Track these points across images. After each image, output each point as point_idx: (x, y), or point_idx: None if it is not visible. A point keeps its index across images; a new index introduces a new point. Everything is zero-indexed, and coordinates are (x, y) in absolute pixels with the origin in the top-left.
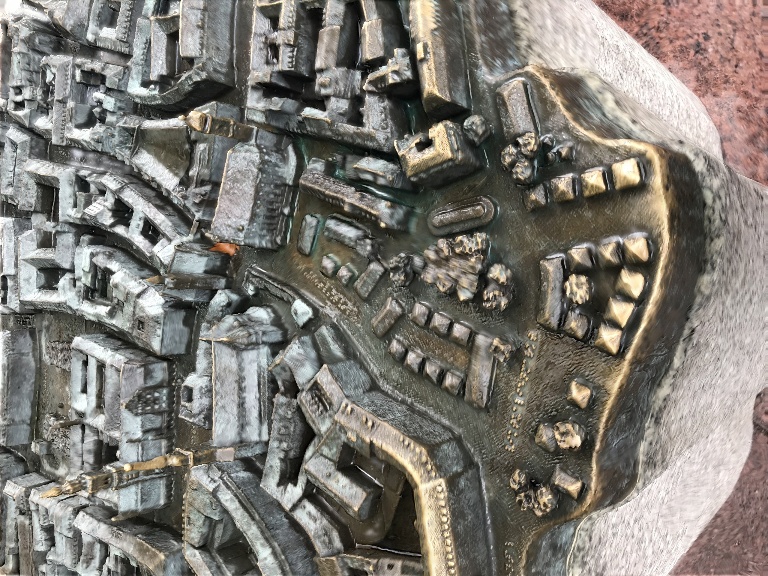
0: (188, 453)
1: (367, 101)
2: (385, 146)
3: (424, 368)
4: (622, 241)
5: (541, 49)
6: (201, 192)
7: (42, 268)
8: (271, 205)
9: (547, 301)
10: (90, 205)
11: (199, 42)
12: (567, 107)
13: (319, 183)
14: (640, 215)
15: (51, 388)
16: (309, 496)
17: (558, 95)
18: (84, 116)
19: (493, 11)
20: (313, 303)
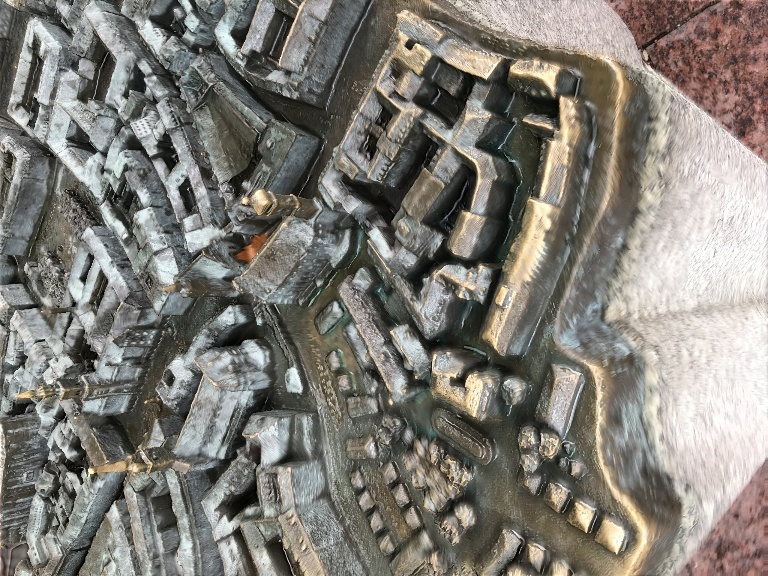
0: (149, 462)
1: (432, 285)
2: (428, 335)
3: (370, 515)
4: (574, 575)
5: (632, 287)
6: (247, 212)
7: None
8: (306, 274)
9: (489, 566)
10: (139, 119)
11: (304, 57)
12: (603, 431)
13: (355, 307)
14: (601, 569)
15: (56, 224)
16: (237, 534)
17: (602, 415)
18: (163, 8)
19: (603, 254)
20: (307, 379)
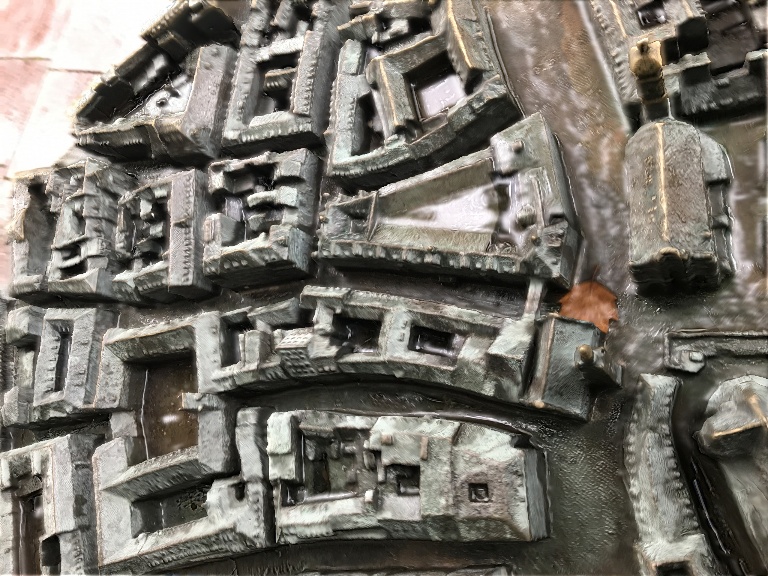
0: None
1: None
2: None
3: None
4: None
5: None
6: (557, 231)
7: (140, 498)
8: None
9: None
10: (281, 340)
11: (484, 54)
12: None
13: None
14: None
15: None
16: None
17: None
18: (230, 232)
19: None
20: None
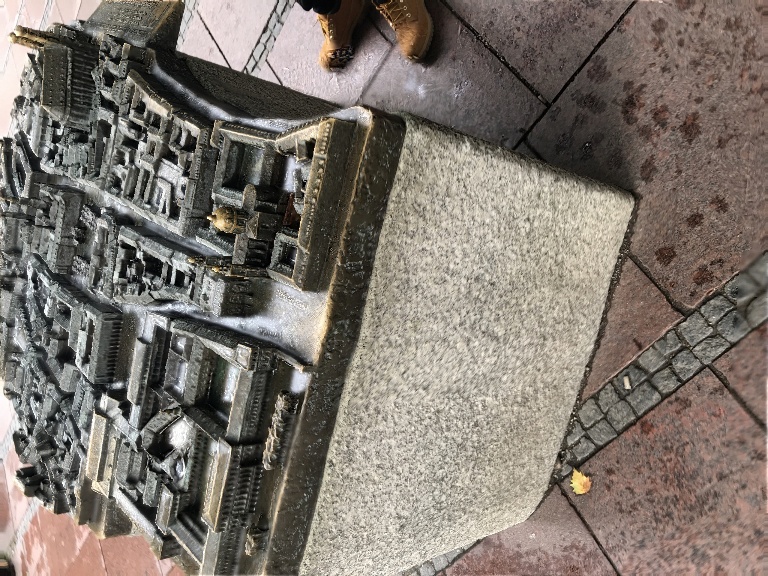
0: None
1: None
2: None
3: None
4: None
5: None
6: None
7: None
8: None
9: None
10: None
11: None
12: None
13: None
14: None
15: None
16: None
17: None
18: None
19: None
20: None
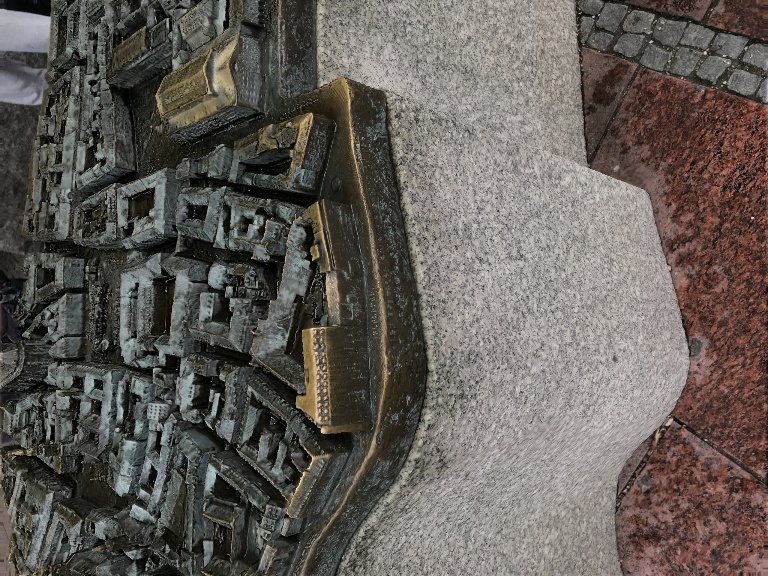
0: None
1: None
2: None
3: None
4: None
5: None
6: None
7: None
8: None
9: None
10: None
11: None
12: None
13: None
14: None
15: (117, 273)
16: None
17: None
18: None
19: None
20: None
